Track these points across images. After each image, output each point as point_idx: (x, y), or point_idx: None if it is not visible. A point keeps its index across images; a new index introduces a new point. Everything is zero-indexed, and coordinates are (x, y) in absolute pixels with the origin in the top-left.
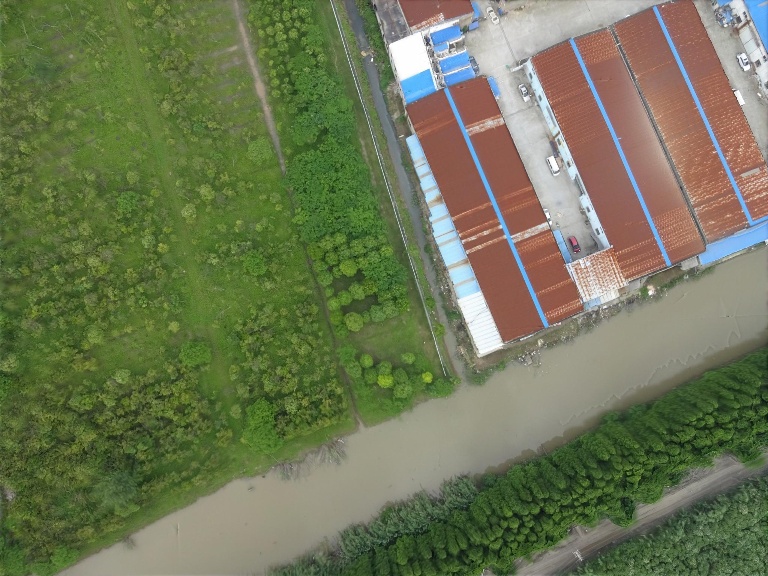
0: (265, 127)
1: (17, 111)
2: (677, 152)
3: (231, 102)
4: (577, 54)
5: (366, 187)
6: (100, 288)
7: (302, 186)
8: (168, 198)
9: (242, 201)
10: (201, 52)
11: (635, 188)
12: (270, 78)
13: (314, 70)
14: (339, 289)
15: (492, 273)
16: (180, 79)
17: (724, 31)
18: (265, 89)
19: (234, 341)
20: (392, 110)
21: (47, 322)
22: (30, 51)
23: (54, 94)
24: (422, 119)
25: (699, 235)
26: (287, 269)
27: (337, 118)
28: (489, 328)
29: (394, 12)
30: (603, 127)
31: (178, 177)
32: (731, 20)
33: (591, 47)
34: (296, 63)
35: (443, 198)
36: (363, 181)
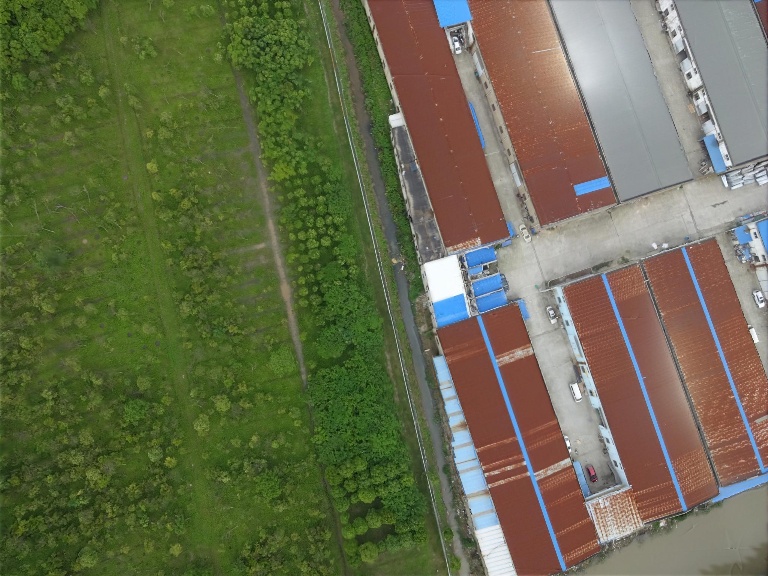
0: (288, 332)
1: (20, 301)
2: (697, 393)
3: (254, 303)
4: (608, 290)
5: (391, 410)
6: (97, 503)
7: (324, 403)
8: (179, 403)
9: (259, 412)
10: (227, 249)
11: (656, 429)
12: (298, 285)
13: (345, 284)
14: (355, 515)
15: (513, 510)
16: (203, 279)
17: (742, 266)
18: (291, 292)
19: (241, 570)
20: (419, 322)
21: (35, 541)
22: (41, 236)
23: (63, 283)
24: (452, 344)
25: (713, 478)
26: (301, 487)
27: (366, 336)
28: (505, 563)
29: (430, 226)
30: (629, 365)
31: (192, 384)
32: (749, 257)
33: (621, 283)
34: (327, 273)
35: (468, 428)
36: (388, 404)
